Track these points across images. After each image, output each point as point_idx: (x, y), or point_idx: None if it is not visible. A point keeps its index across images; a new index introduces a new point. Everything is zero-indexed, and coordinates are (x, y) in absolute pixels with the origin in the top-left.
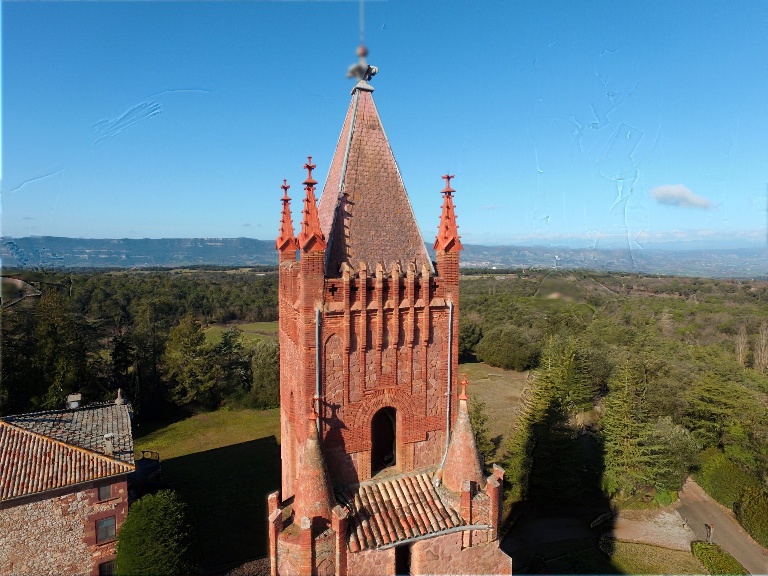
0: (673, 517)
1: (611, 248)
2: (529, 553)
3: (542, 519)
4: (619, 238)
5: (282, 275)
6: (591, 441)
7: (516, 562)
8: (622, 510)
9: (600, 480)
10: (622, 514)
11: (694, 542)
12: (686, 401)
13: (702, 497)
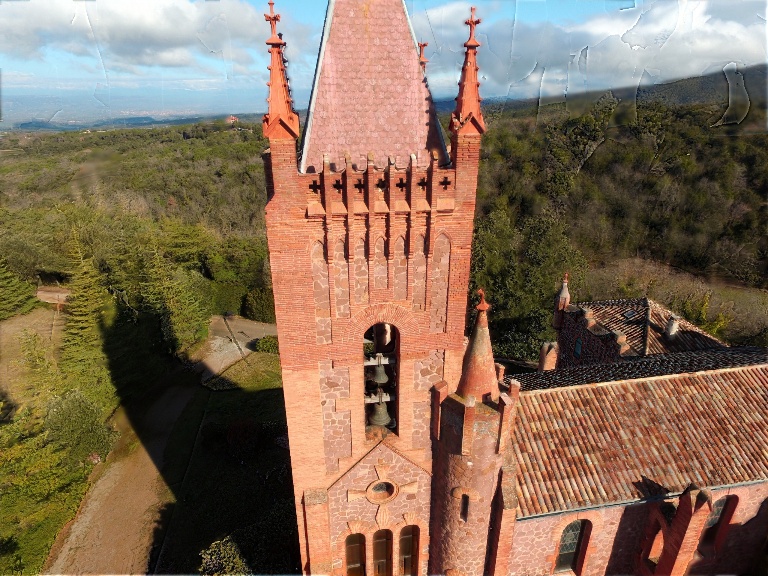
0: (219, 341)
1: (19, 104)
2: (180, 435)
3: (150, 408)
4: (26, 90)
5: (349, 177)
6: (147, 317)
7: (182, 449)
8: (189, 359)
9: (163, 347)
10: (193, 361)
11: None
12: (144, 255)
13: (214, 318)
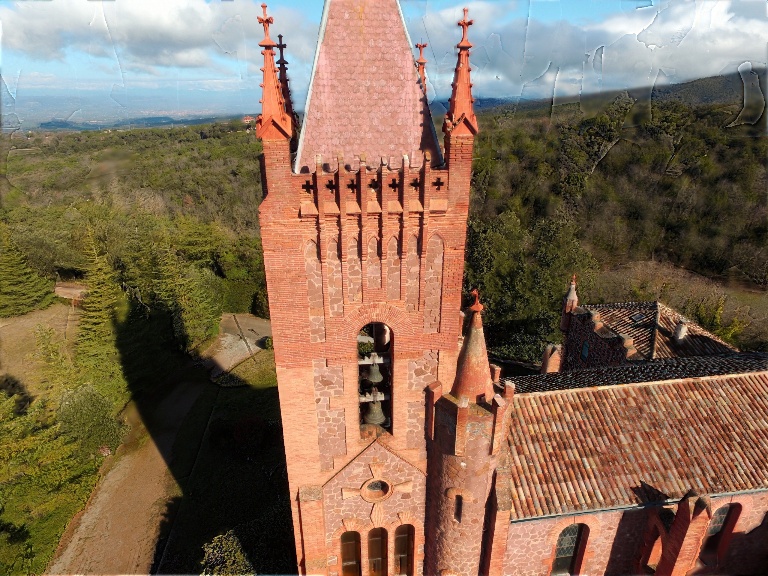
0: (229, 338)
1: (39, 104)
2: (188, 430)
3: (160, 403)
4: (46, 91)
5: (341, 177)
6: (159, 313)
7: (190, 444)
8: (200, 355)
9: (174, 343)
10: (203, 358)
11: (258, 343)
12: (159, 253)
13: (226, 316)
